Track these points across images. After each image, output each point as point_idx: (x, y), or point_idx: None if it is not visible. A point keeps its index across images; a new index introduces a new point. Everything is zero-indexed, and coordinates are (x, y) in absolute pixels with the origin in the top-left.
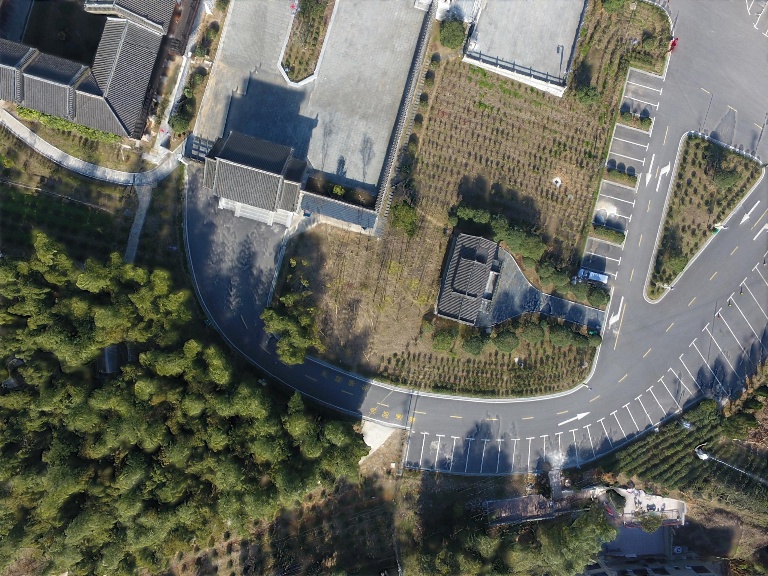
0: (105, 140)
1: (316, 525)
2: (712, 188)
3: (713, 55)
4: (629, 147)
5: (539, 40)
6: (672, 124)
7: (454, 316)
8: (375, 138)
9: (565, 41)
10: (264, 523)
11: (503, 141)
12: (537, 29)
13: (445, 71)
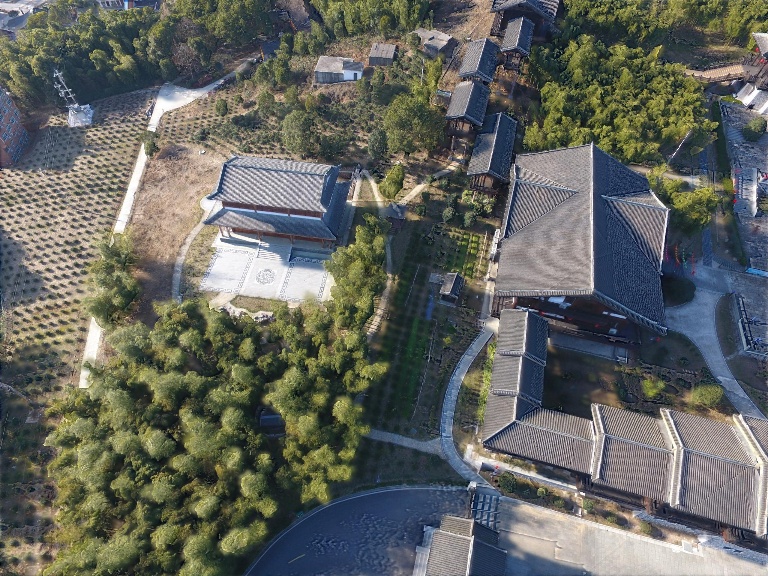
0: (480, 412)
1: None
2: None
3: None
4: None
5: None
6: None
7: None
8: None
9: None
10: None
11: None
12: None
13: None
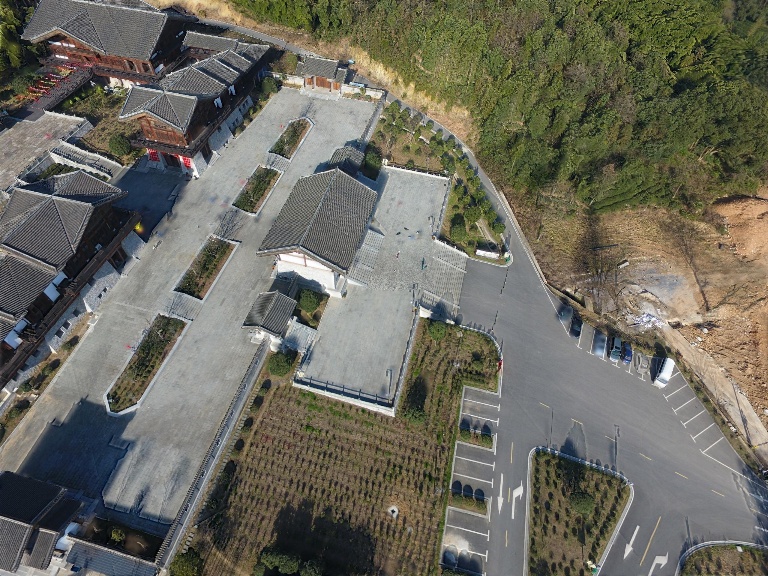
0: None
1: None
2: (576, 512)
3: (544, 372)
4: (474, 467)
5: (368, 365)
6: (516, 440)
7: None
8: (185, 468)
9: (394, 365)
10: None
11: (330, 466)
12: (367, 356)
13: (274, 396)
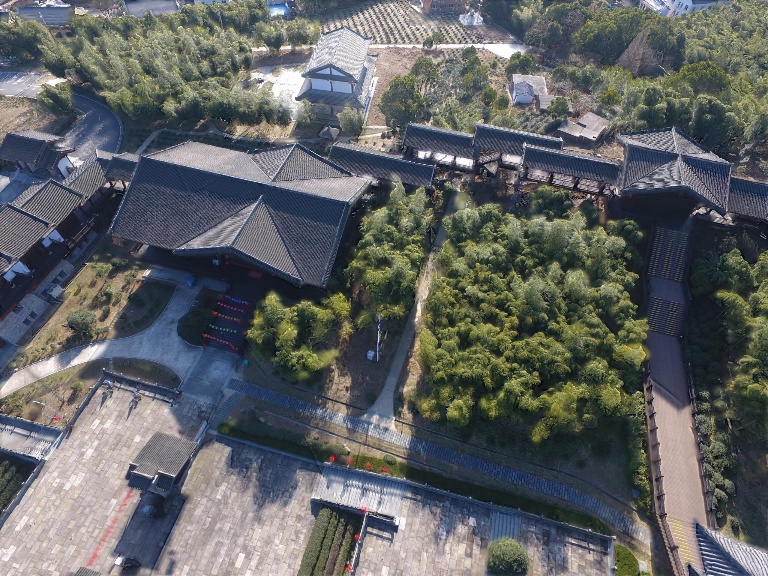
0: None
1: None
2: None
3: None
4: None
5: None
6: None
7: None
8: None
9: None
10: None
11: None
12: None
13: None
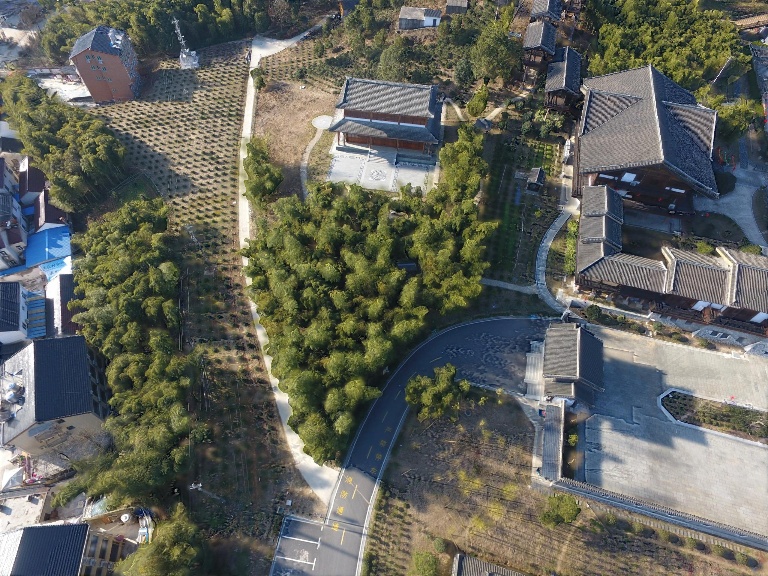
0: (567, 266)
1: (244, 421)
2: None
3: None
4: None
5: None
6: None
7: (460, 574)
8: (635, 483)
9: None
10: (256, 376)
11: None
12: None
13: (740, 574)
